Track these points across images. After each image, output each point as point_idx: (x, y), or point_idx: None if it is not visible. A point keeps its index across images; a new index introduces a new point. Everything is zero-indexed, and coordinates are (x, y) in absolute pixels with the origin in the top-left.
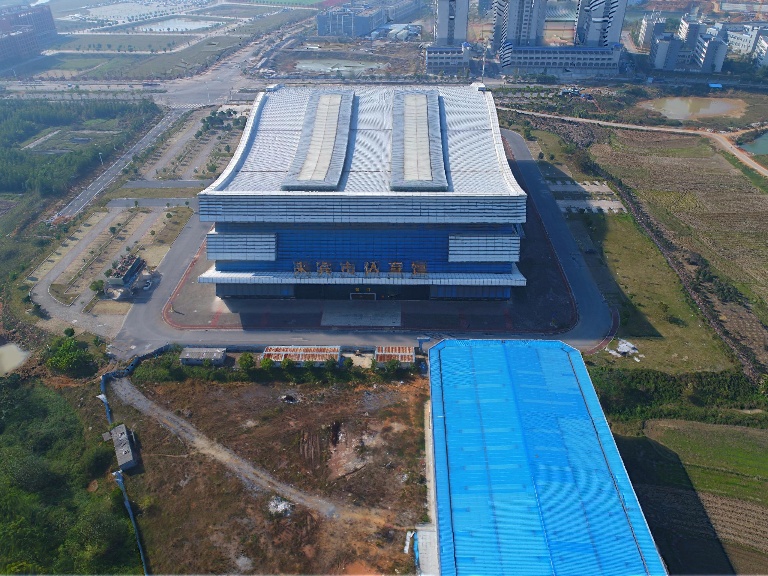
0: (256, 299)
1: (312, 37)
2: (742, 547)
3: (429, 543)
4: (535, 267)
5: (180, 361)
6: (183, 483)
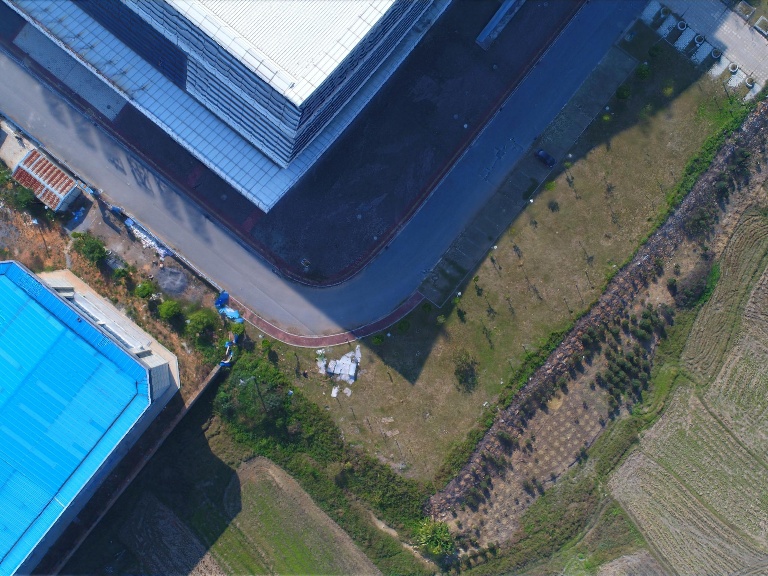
0: None
1: None
2: None
3: None
4: (415, 132)
5: None
6: None
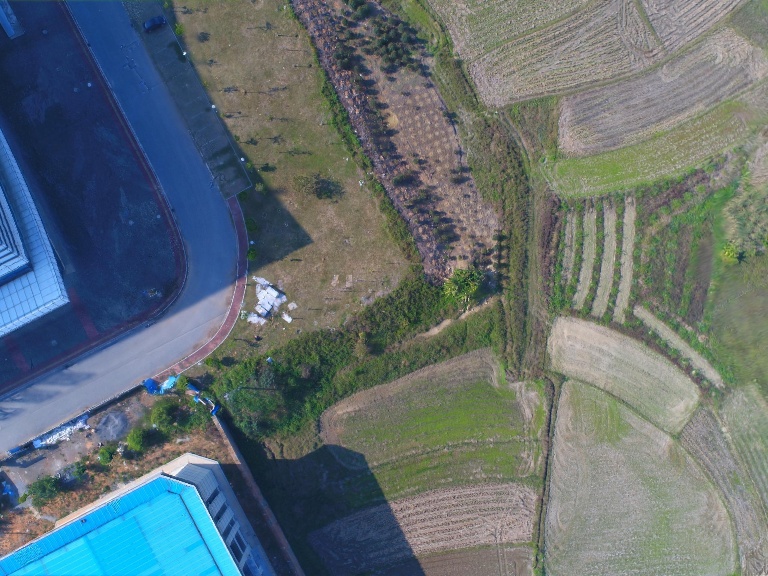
0: None
1: None
2: (436, 554)
3: None
4: (73, 134)
5: None
6: None
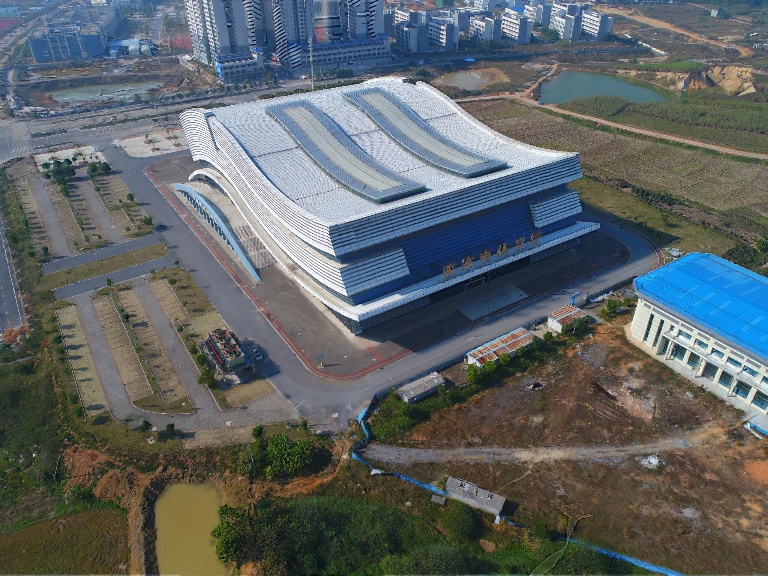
0: (387, 323)
1: (35, 65)
2: None
3: (765, 424)
4: None
5: None
6: (561, 492)
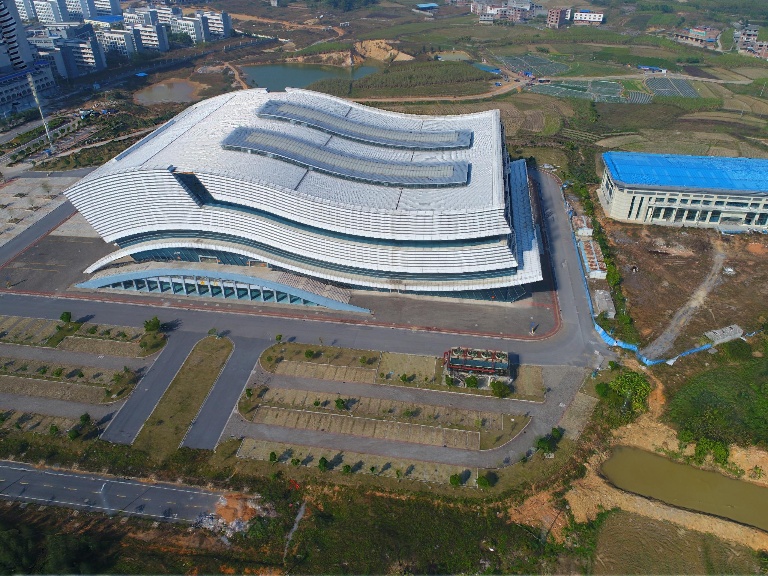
0: None
1: None
2: None
3: None
4: None
5: (611, 320)
6: (734, 308)
